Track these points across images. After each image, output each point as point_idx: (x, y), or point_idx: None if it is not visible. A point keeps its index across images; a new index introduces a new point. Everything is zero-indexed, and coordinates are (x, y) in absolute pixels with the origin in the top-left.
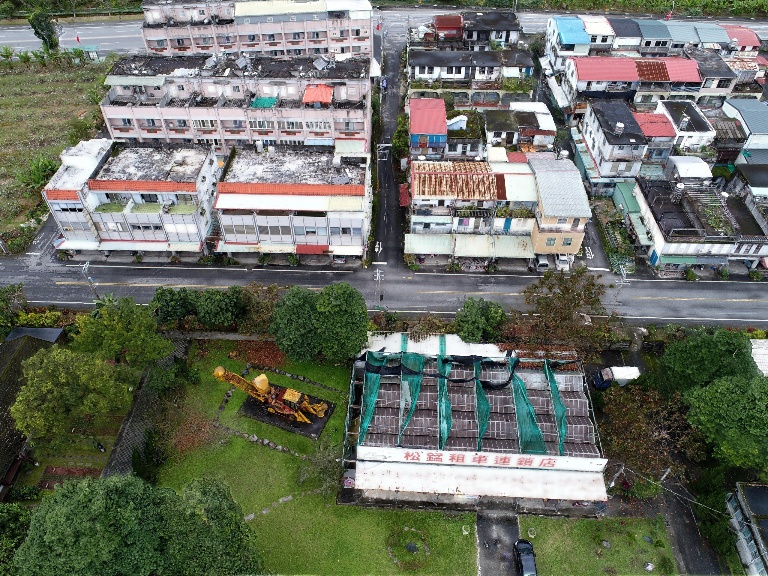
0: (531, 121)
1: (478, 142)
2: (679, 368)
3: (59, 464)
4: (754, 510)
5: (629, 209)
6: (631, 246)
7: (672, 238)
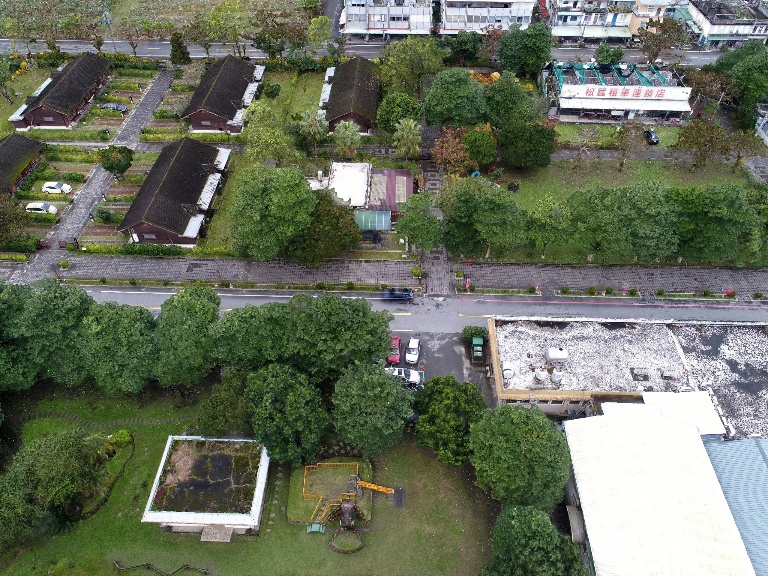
0: None
1: None
2: (725, 61)
3: None
4: None
5: (686, 18)
6: None
7: (715, 21)
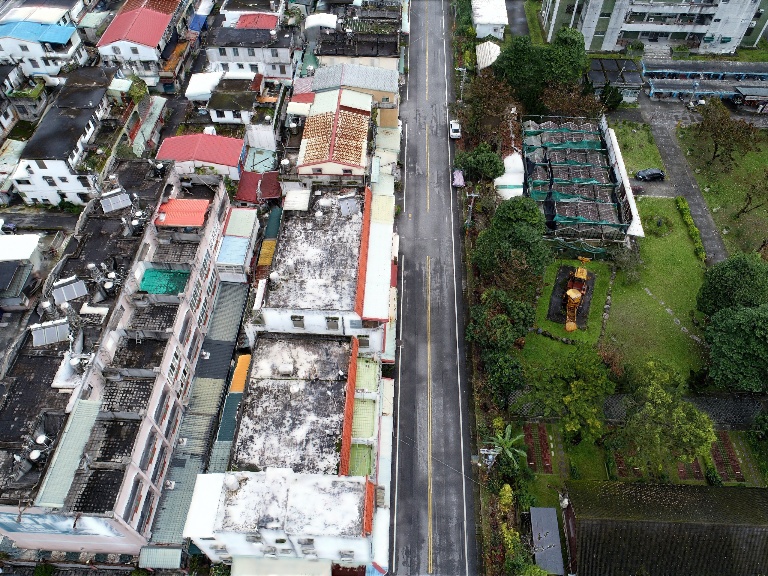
0: (240, 83)
1: (245, 130)
2: (530, 73)
3: (675, 468)
4: (604, 81)
5: None
6: None
7: None
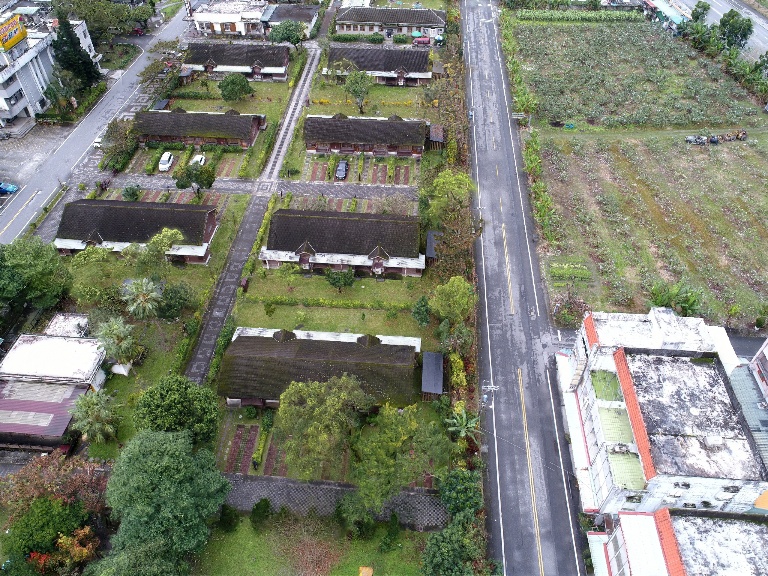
0: None
1: None
2: None
3: None
4: None
5: None
6: None
7: None
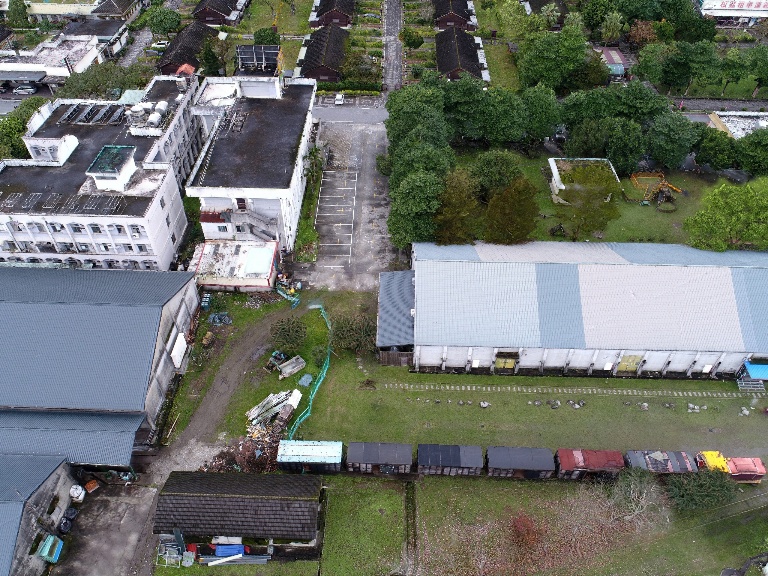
0: None
1: None
2: None
3: None
4: None
5: None
6: None
7: None
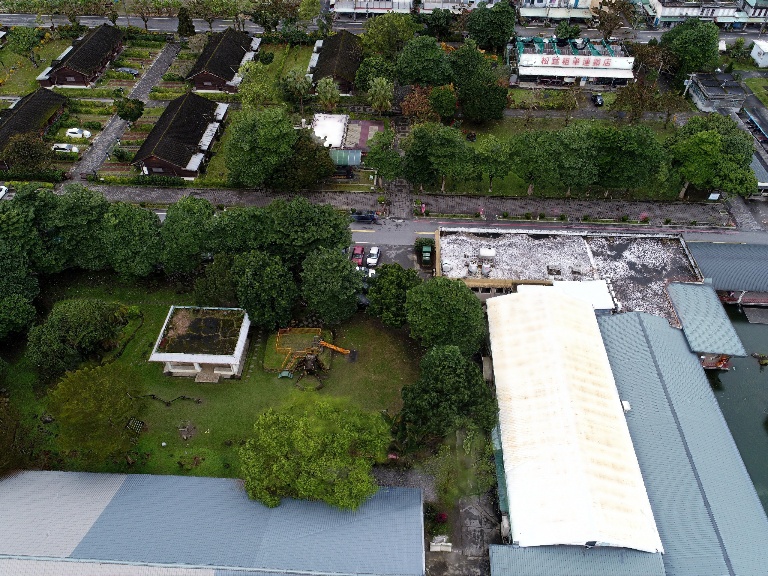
0: None
1: None
2: (668, 36)
3: None
4: (699, 78)
5: (643, 2)
6: (644, 17)
7: (666, 4)
